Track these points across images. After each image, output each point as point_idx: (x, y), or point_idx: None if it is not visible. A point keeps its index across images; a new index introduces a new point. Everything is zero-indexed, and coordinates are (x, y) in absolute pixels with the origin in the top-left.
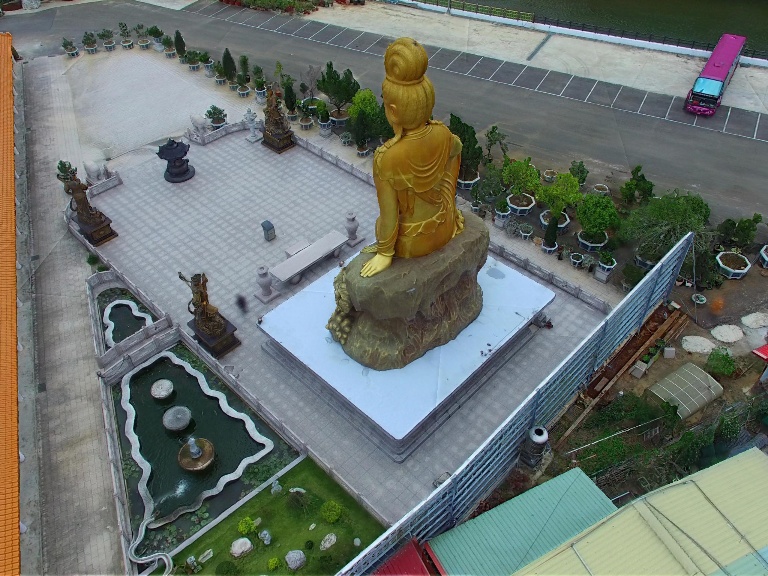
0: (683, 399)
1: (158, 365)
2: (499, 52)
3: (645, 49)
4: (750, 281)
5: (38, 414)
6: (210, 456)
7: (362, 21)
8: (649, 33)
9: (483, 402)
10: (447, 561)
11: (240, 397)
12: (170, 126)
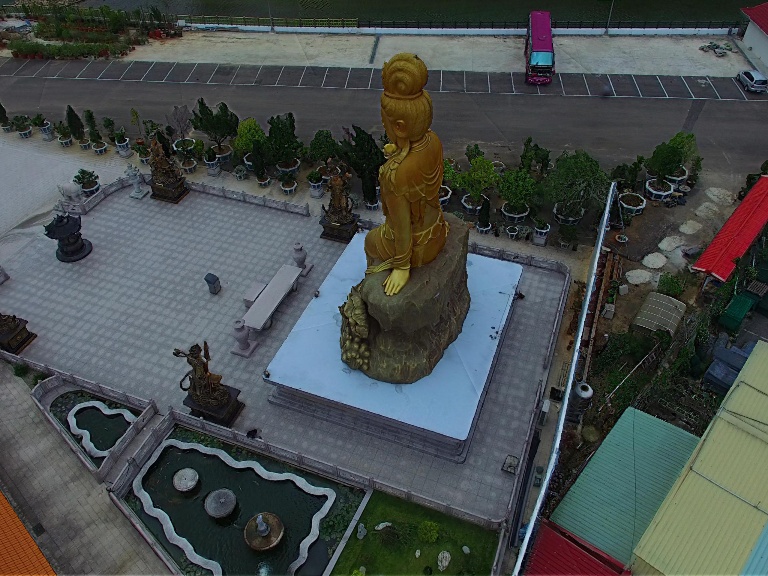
0: (664, 323)
1: (163, 458)
2: (341, 60)
3: (466, 36)
4: (649, 213)
5: (51, 560)
6: (280, 527)
7: (189, 53)
8: (466, 21)
9: (503, 382)
10: (576, 529)
11: (273, 458)
12: (31, 203)
